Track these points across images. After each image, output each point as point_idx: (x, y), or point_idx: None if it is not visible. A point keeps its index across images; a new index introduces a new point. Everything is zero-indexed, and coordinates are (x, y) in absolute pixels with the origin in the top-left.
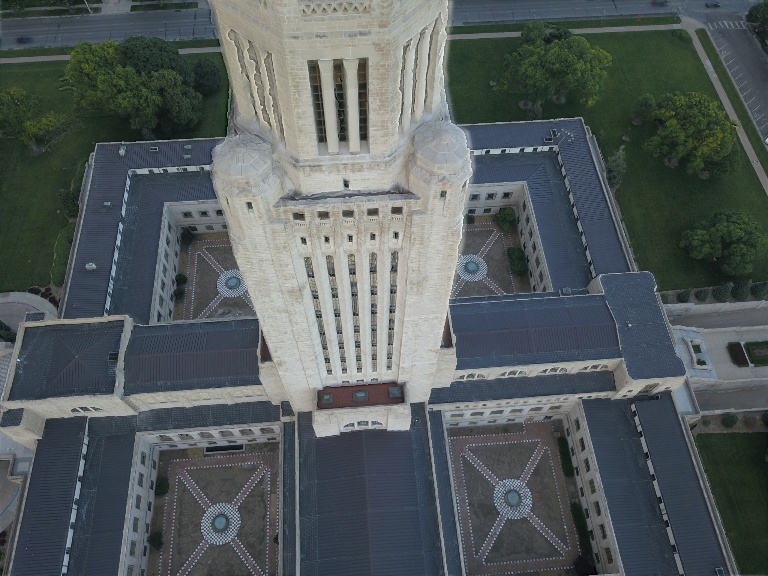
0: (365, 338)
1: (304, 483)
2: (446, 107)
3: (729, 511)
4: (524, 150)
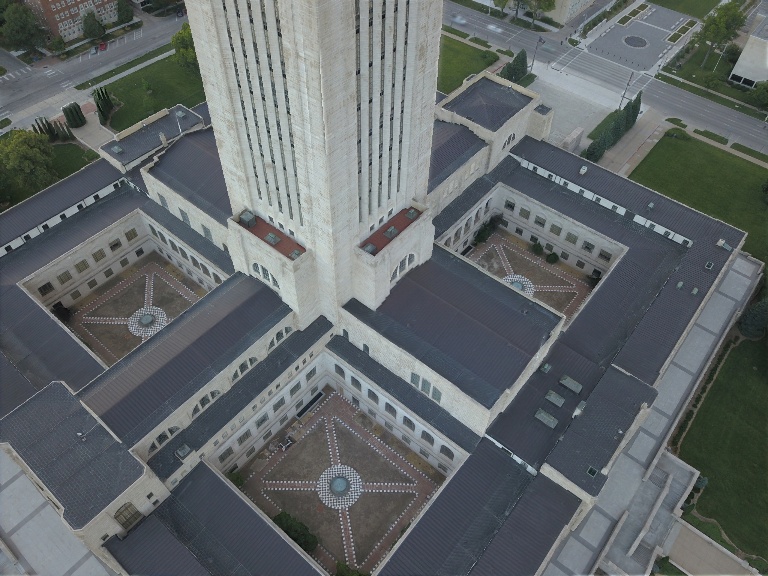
0: None
1: None
2: None
3: None
4: None
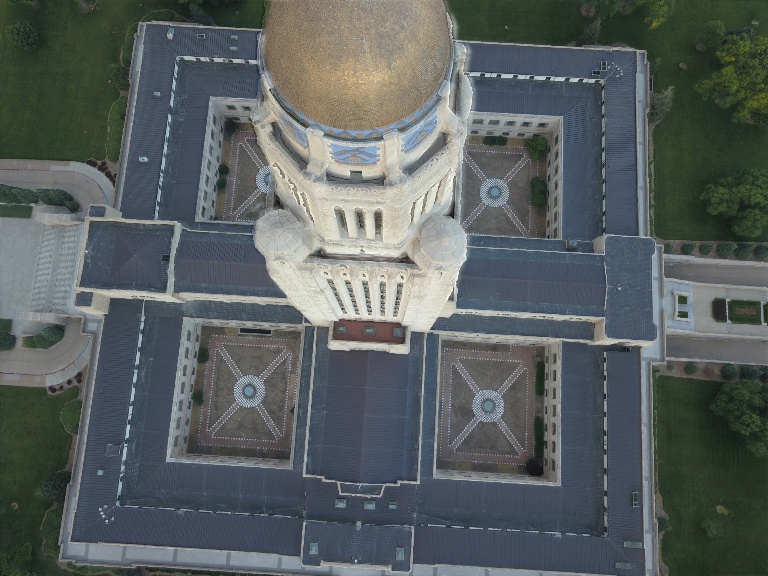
0: (375, 307)
1: (317, 384)
2: (460, 175)
3: (666, 441)
4: (569, 79)
